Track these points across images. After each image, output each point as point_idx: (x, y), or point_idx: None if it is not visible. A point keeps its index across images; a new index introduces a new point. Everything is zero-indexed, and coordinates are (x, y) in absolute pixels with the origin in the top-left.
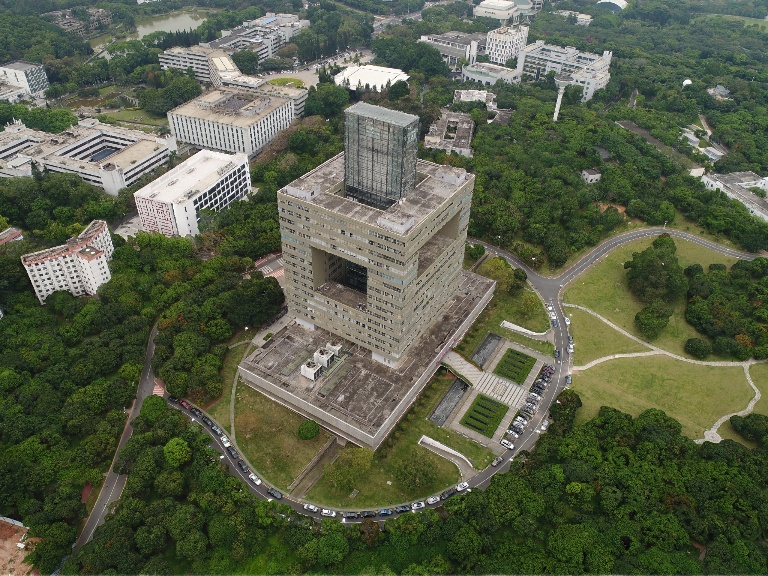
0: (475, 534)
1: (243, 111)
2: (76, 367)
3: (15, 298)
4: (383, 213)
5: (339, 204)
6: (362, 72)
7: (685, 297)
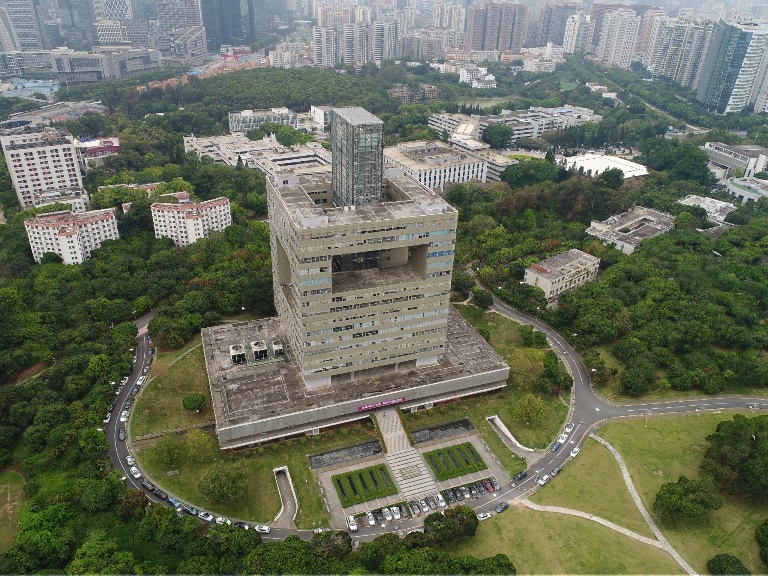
0: (211, 572)
1: (427, 159)
2: (113, 284)
3: (140, 233)
4: None
5: (296, 196)
6: (598, 160)
7: None
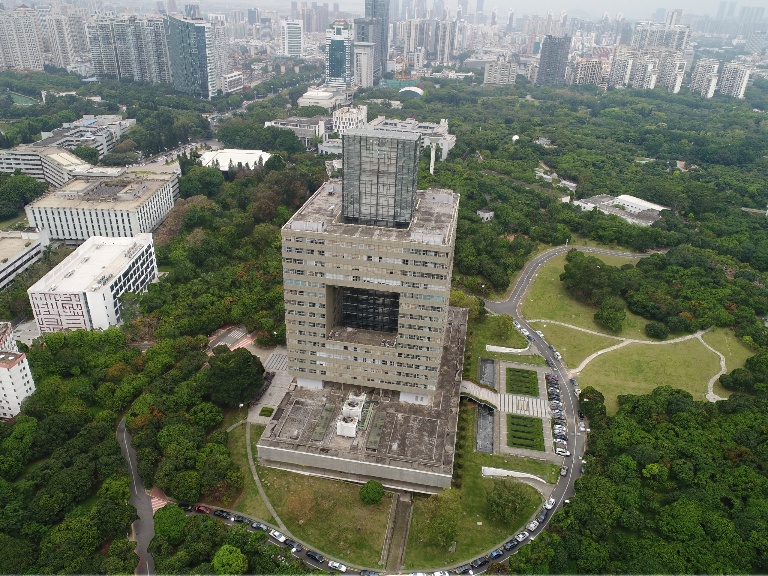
0: None
1: (122, 195)
2: (39, 501)
3: None
4: None
5: (355, 231)
6: (223, 155)
7: (618, 295)
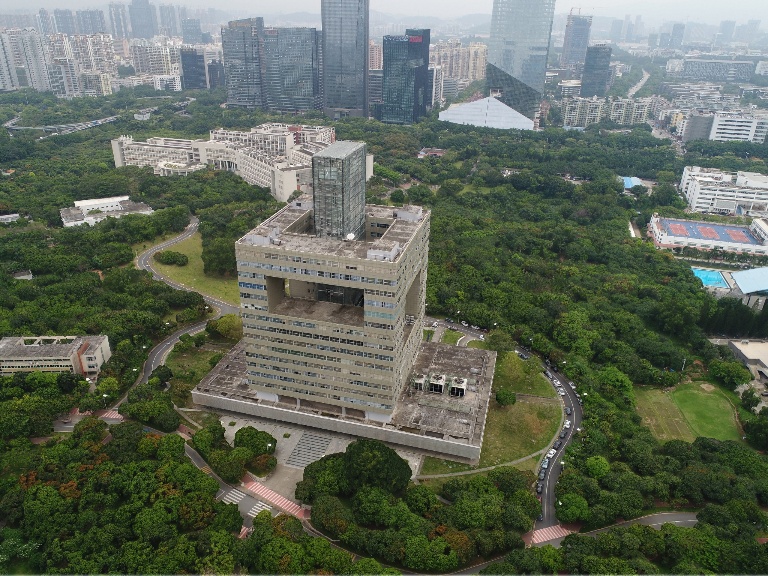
0: None
1: None
2: None
3: None
4: (408, 214)
5: (394, 237)
6: None
7: None
